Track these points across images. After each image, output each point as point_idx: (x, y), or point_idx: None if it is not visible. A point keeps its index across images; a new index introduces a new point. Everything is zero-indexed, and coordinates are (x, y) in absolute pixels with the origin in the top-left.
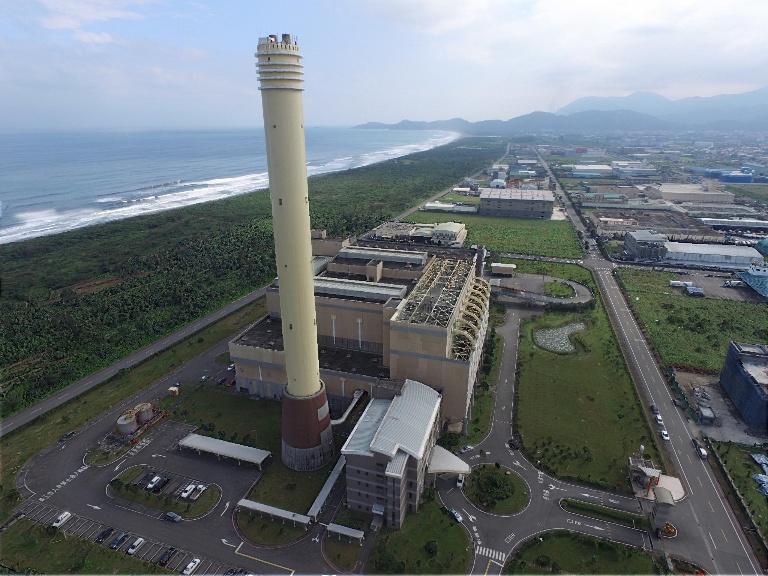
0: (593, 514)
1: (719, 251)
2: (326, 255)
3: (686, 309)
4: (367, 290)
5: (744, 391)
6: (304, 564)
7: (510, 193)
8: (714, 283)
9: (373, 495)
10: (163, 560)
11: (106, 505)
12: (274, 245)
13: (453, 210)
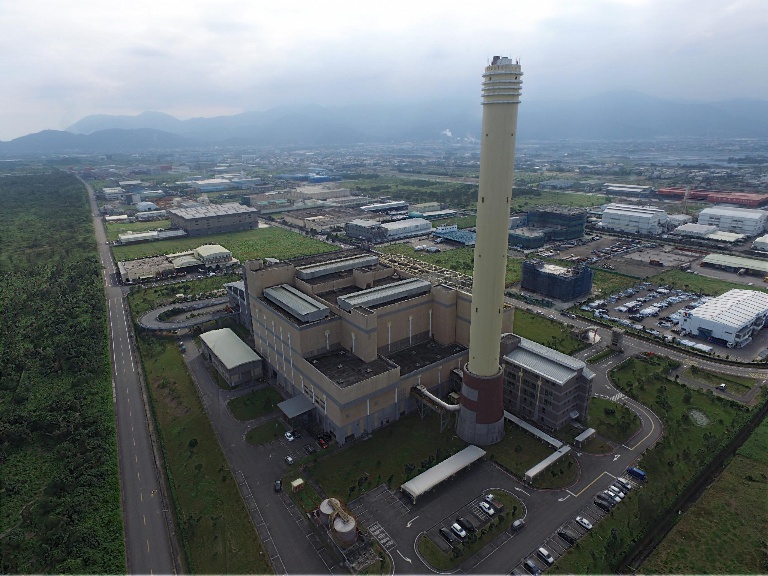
0: (601, 359)
1: (410, 224)
2: (278, 284)
3: (447, 260)
4: (406, 288)
5: (549, 283)
6: (601, 465)
7: (207, 210)
8: (429, 243)
9: (570, 407)
10: (574, 537)
11: (470, 575)
12: (4, 329)
13: (159, 237)
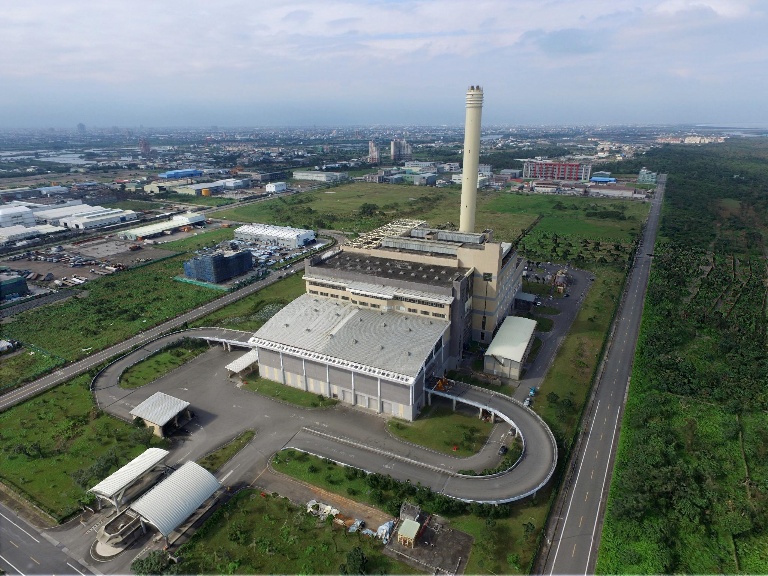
0: None
1: None
2: None
3: None
4: None
5: (239, 262)
6: None
7: None
8: None
9: None
10: None
11: None
12: None
13: None
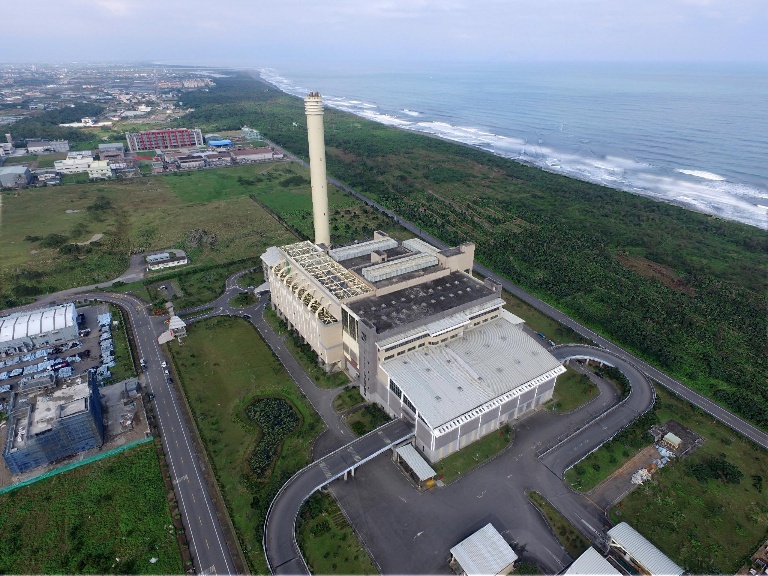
0: None
1: None
2: None
3: None
4: None
5: None
6: None
7: None
8: None
9: None
10: None
11: None
12: None
13: None
